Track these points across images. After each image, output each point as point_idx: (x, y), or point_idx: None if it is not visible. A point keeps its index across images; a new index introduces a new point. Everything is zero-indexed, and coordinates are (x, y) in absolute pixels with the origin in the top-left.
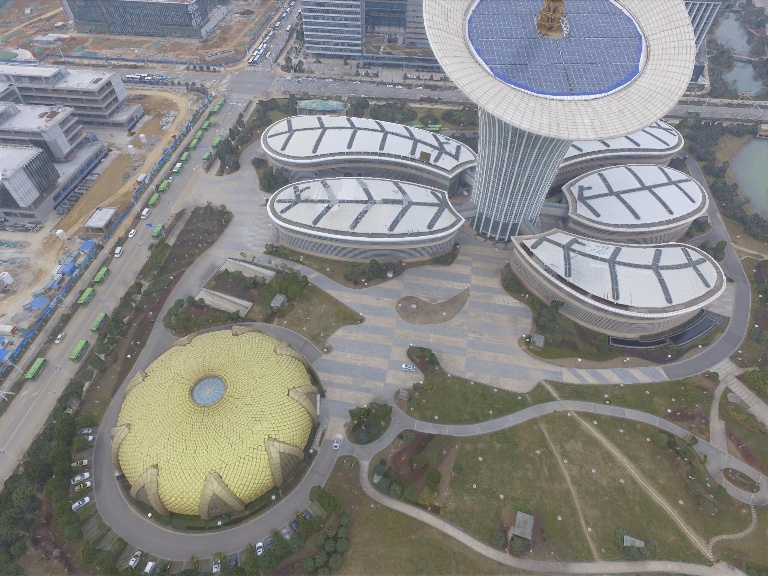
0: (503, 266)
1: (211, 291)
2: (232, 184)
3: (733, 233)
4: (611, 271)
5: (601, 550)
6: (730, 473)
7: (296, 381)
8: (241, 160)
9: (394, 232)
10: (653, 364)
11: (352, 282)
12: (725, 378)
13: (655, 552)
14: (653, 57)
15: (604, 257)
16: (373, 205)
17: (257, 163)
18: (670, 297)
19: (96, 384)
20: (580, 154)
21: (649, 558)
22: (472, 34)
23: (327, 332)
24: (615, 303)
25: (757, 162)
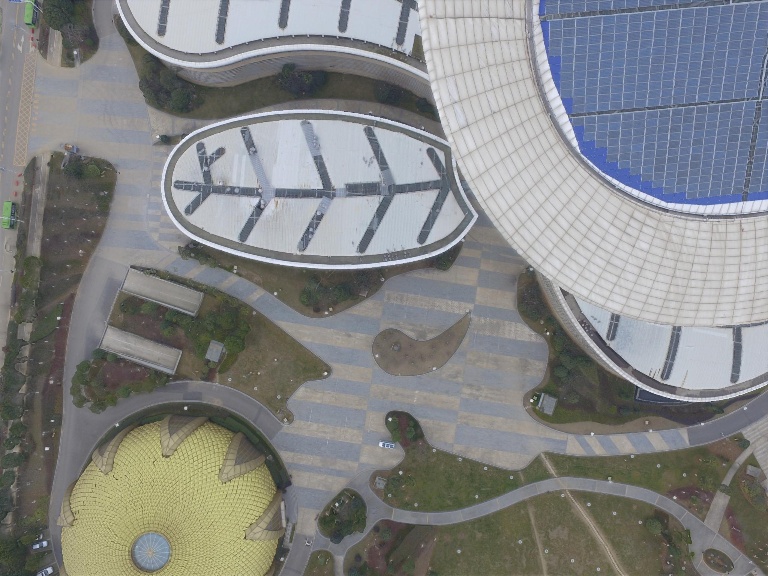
0: (524, 268)
1: (121, 330)
2: (96, 89)
3: None
4: (673, 334)
5: None
6: (711, 556)
7: (252, 514)
8: (96, 18)
9: (366, 253)
10: (679, 426)
11: (311, 308)
12: (756, 442)
13: None
14: None
15: None
16: (331, 201)
17: (125, 37)
18: (738, 374)
19: (24, 478)
20: None
21: None
22: None
23: (285, 393)
24: (661, 383)
25: None
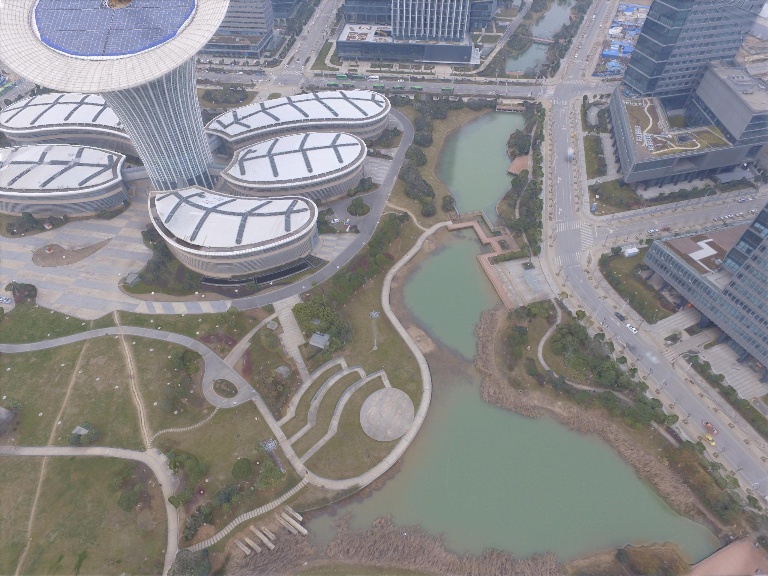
0: None
1: None
2: None
3: (394, 192)
4: (203, 217)
5: (58, 438)
6: (218, 383)
7: None
8: None
9: (45, 188)
10: (226, 298)
11: (10, 233)
12: (281, 310)
13: (103, 441)
14: (192, 23)
15: (208, 206)
16: (38, 165)
17: None
18: (241, 239)
19: None
20: (276, 123)
21: (95, 445)
22: (40, 6)
23: None
24: (191, 244)
25: (477, 133)
